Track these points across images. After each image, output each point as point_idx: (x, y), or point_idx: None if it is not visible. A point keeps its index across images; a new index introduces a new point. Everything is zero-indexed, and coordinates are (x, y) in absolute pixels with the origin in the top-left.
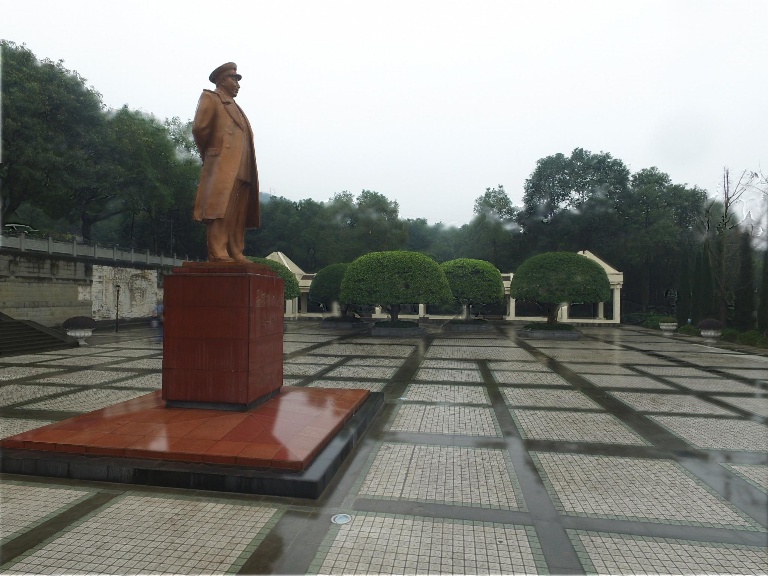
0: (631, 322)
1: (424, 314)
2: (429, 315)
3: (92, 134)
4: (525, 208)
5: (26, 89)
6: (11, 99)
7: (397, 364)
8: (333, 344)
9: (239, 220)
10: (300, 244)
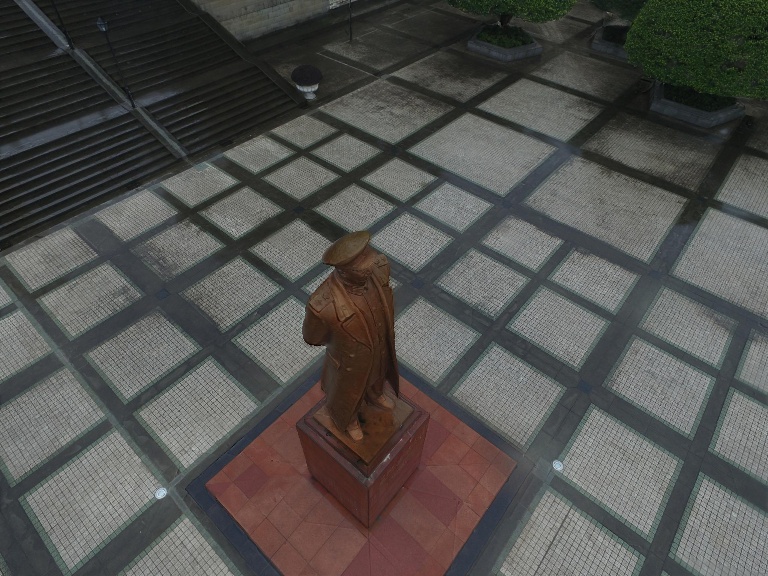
0: None
1: None
2: None
3: None
4: None
5: None
6: None
7: (615, 302)
8: (574, 159)
9: None
10: None
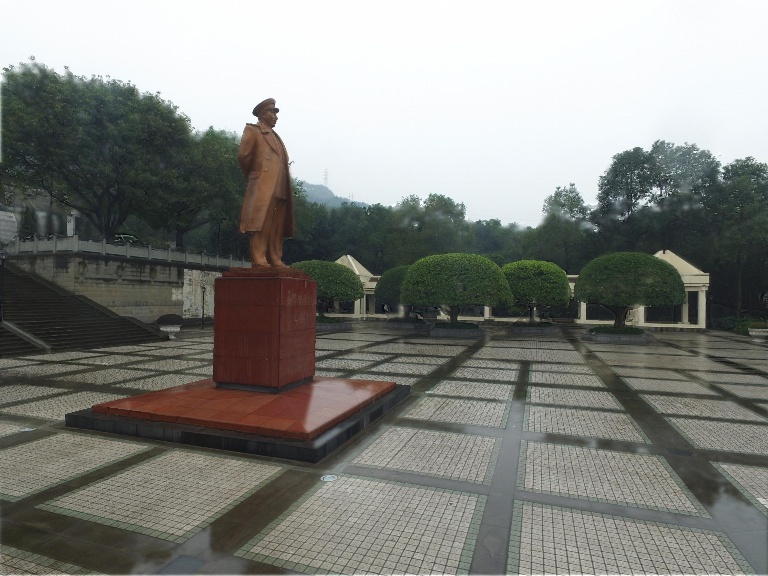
0: (721, 327)
1: (489, 316)
2: (494, 317)
3: (182, 155)
4: (599, 206)
5: (130, 120)
6: (118, 130)
7: (440, 362)
8: (389, 343)
9: (278, 231)
10: (369, 247)
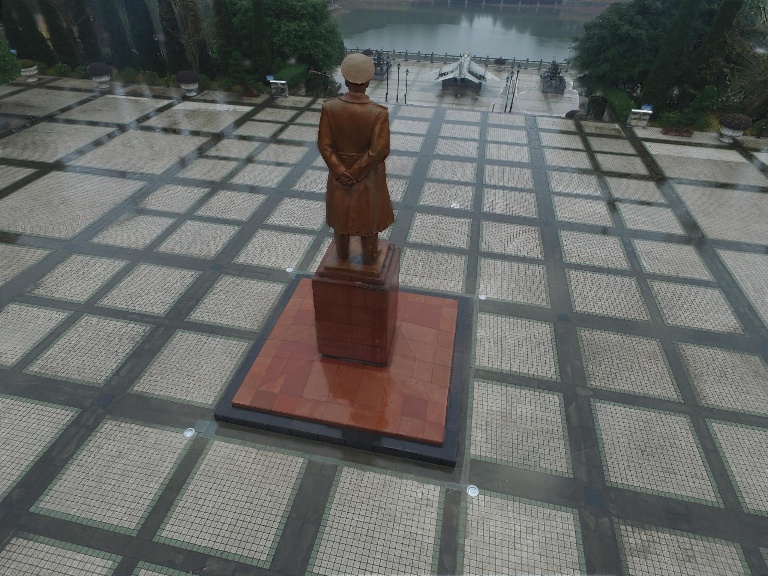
0: None
1: None
2: None
3: None
4: None
5: None
6: None
7: (114, 262)
8: None
9: None
10: None
